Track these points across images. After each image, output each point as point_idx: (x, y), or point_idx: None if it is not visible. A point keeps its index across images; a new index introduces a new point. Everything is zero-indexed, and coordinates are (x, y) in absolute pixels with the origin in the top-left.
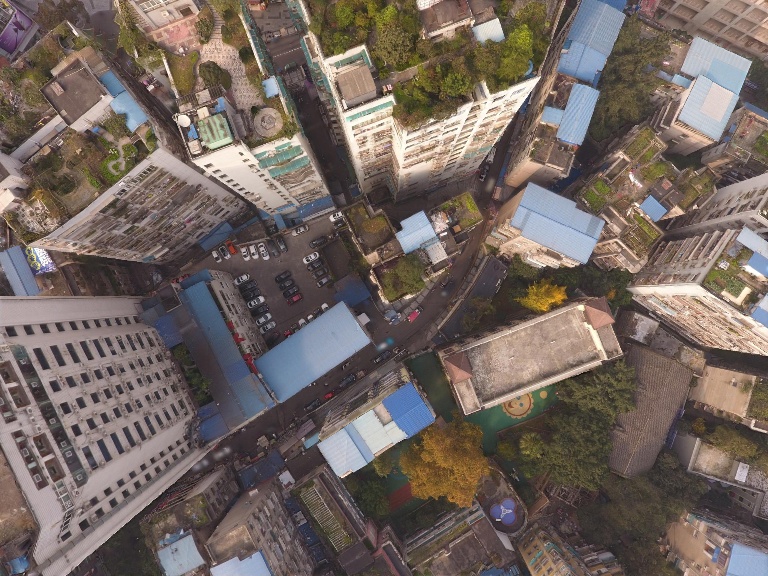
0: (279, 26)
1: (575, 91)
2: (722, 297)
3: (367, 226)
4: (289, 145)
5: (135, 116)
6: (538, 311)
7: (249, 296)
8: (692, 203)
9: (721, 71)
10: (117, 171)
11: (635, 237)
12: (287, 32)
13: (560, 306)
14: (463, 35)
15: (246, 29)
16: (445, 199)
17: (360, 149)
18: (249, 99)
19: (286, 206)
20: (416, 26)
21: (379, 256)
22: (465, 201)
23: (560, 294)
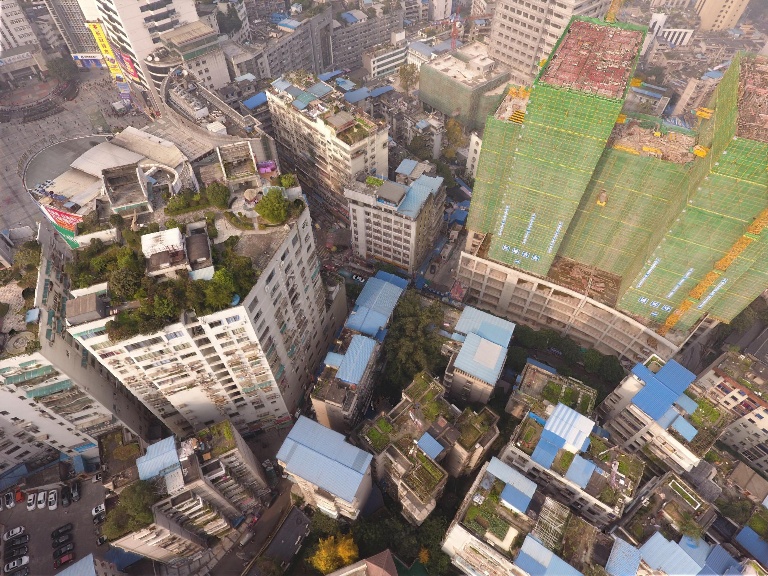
0: None
1: (355, 340)
2: (486, 540)
3: (117, 453)
4: (33, 362)
5: None
6: (323, 573)
7: (11, 555)
8: (475, 442)
9: (490, 330)
10: None
11: (415, 476)
12: None
13: (345, 565)
14: (181, 276)
15: (38, 277)
16: (264, 446)
17: (124, 375)
18: (16, 325)
19: (86, 446)
20: (139, 267)
21: (113, 484)
22: (224, 429)
23: (341, 547)
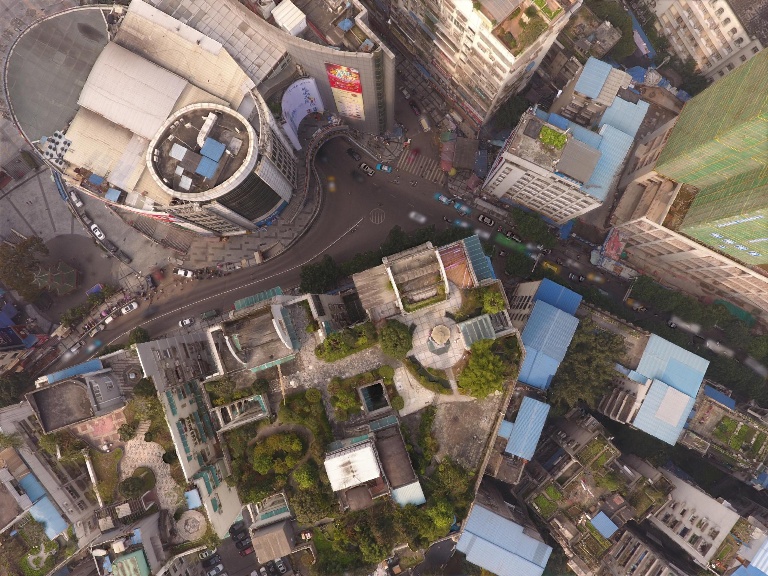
0: (240, 257)
1: (525, 405)
2: None
3: (306, 561)
4: None
5: (54, 524)
6: None
7: None
8: (646, 512)
9: (678, 372)
10: (37, 567)
11: (586, 550)
12: (248, 263)
13: None
14: None
15: (171, 432)
16: None
17: None
18: (173, 498)
19: None
20: (331, 503)
21: None
22: None
23: None
